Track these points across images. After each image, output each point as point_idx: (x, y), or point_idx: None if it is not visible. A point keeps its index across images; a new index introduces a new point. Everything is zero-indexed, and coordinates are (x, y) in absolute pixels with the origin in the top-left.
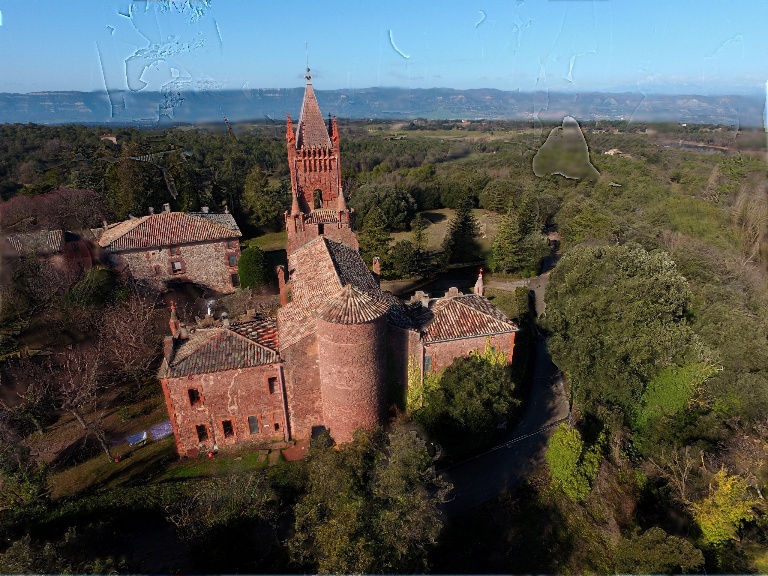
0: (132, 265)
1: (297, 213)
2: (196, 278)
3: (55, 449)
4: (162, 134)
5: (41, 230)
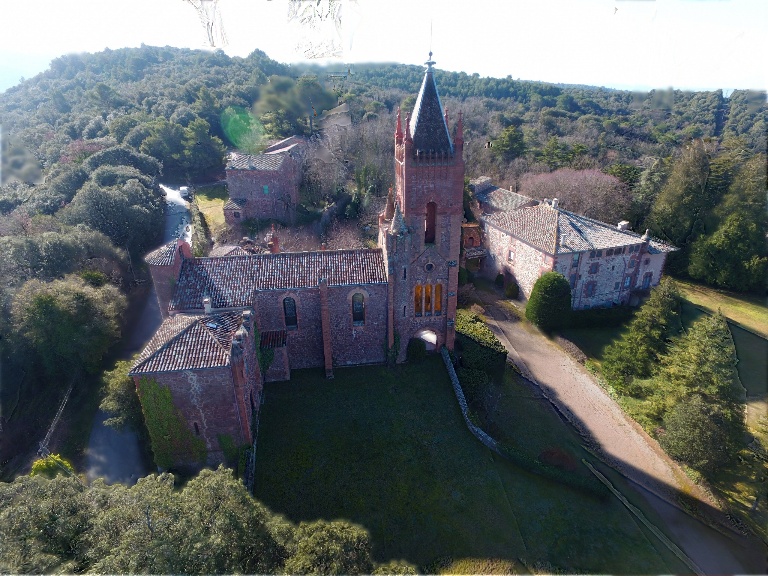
0: (492, 238)
1: (384, 214)
2: (519, 276)
3: None
4: (664, 129)
5: None
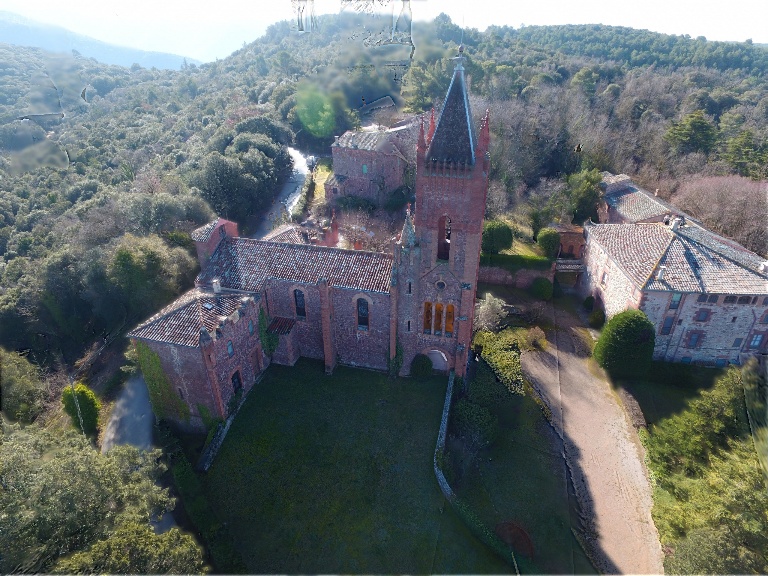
0: (592, 252)
1: None
2: None
3: None
4: None
5: (560, 184)
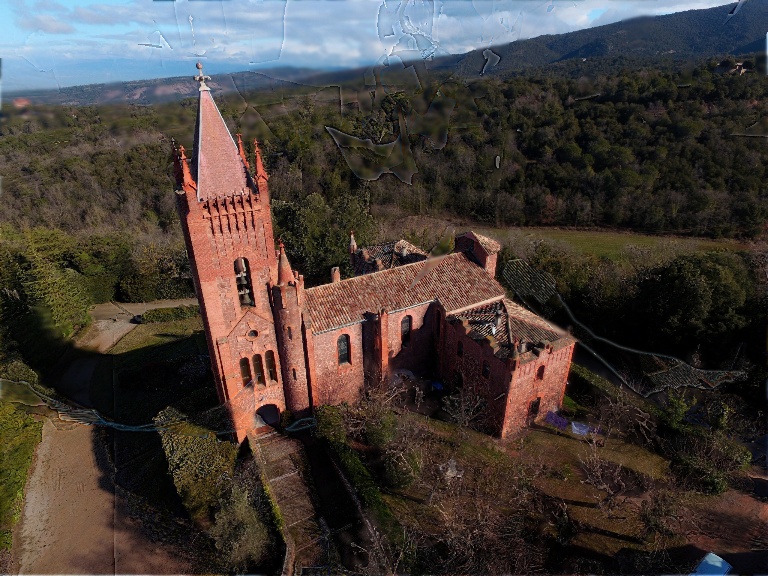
0: None
1: (293, 275)
2: None
3: (640, 504)
4: None
5: None
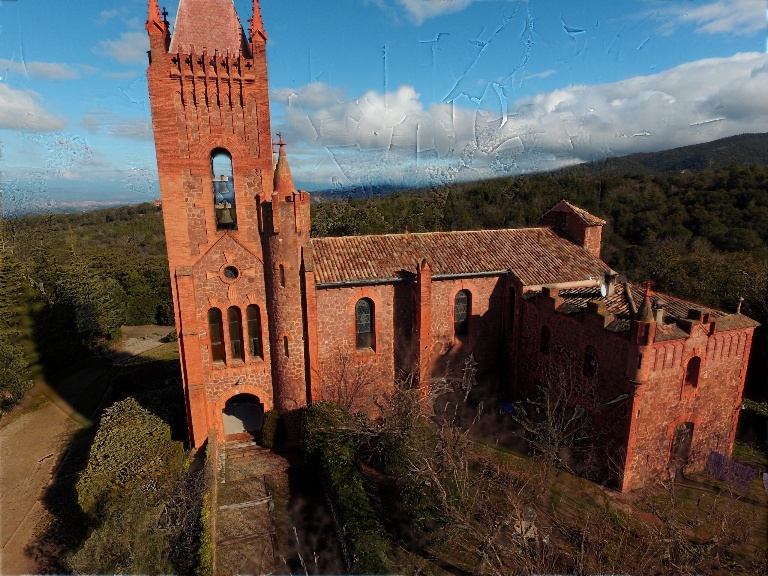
0: None
1: None
2: None
3: None
4: None
5: None
